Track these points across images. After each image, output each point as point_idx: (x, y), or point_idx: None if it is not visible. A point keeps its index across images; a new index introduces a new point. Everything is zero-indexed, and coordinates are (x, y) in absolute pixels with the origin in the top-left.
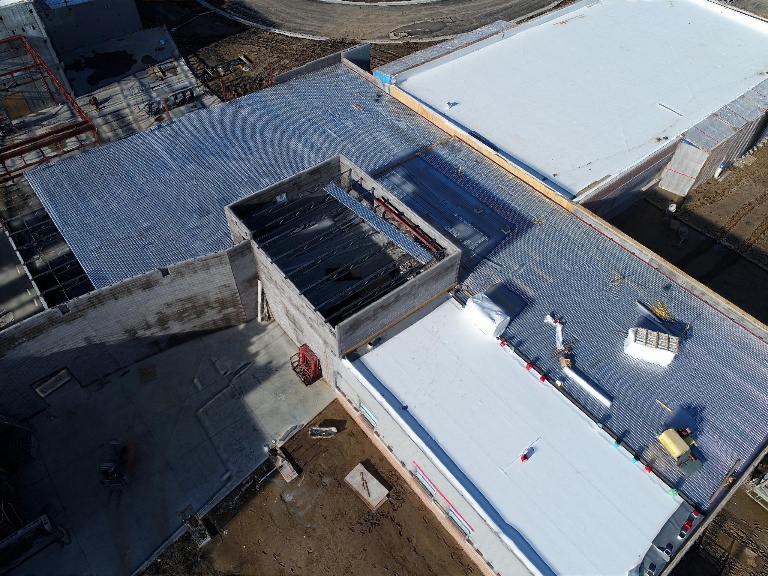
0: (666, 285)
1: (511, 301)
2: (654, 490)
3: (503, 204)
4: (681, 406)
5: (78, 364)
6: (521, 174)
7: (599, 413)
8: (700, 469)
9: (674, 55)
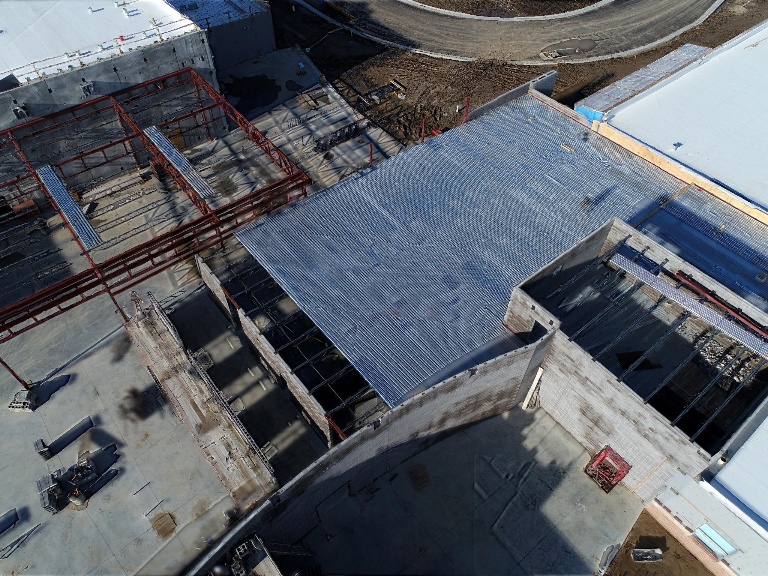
0: None
1: None
2: None
3: None
4: None
5: (359, 475)
6: None
7: None
8: None
9: None
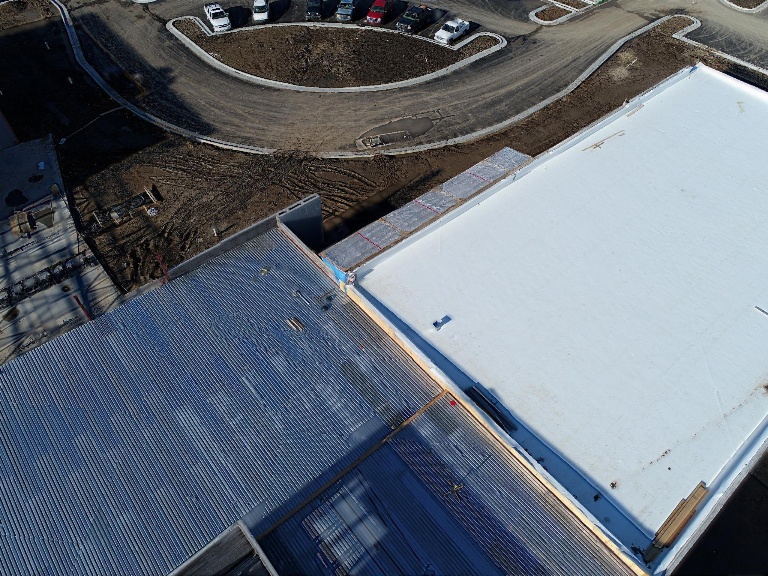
0: None
1: None
2: None
3: (531, 569)
4: None
5: None
6: (558, 493)
7: None
8: None
9: (761, 204)
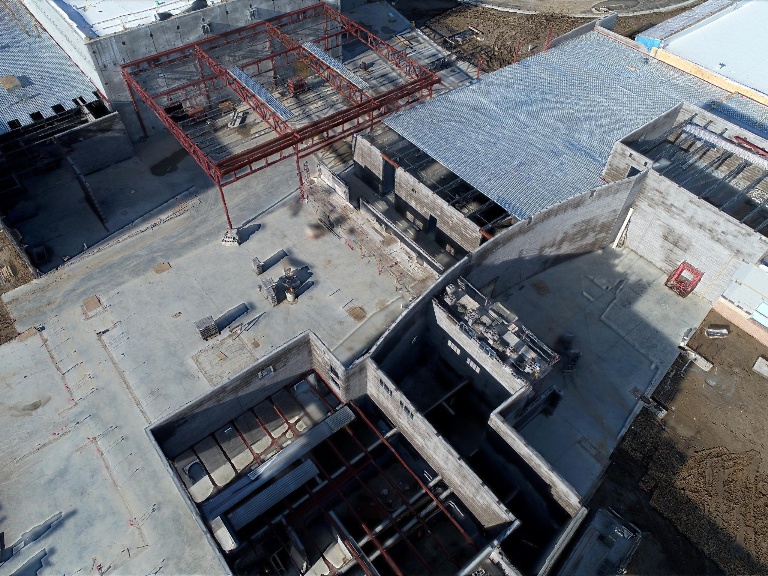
0: None
1: None
2: None
3: None
4: None
5: (504, 275)
6: None
7: None
8: None
9: None
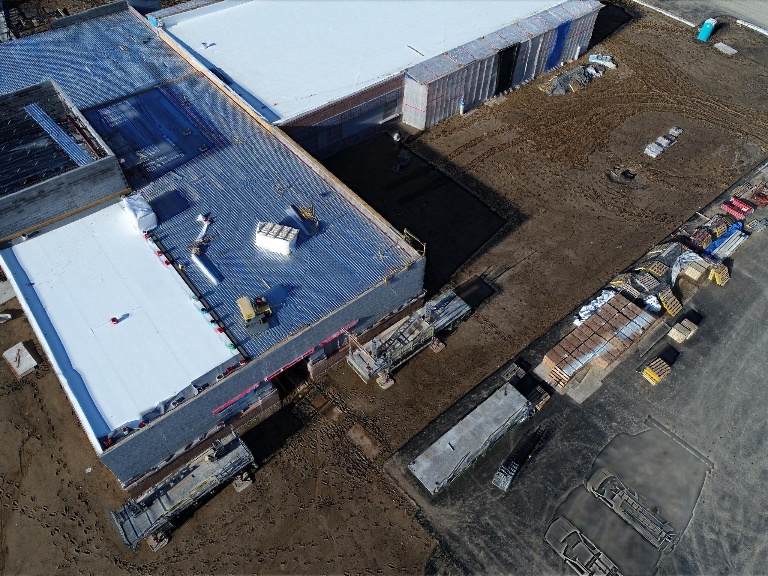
0: (326, 192)
1: (176, 204)
2: (217, 345)
3: (214, 128)
4: (281, 285)
5: None
6: (240, 103)
7: (205, 289)
8: (269, 331)
9: (446, 4)
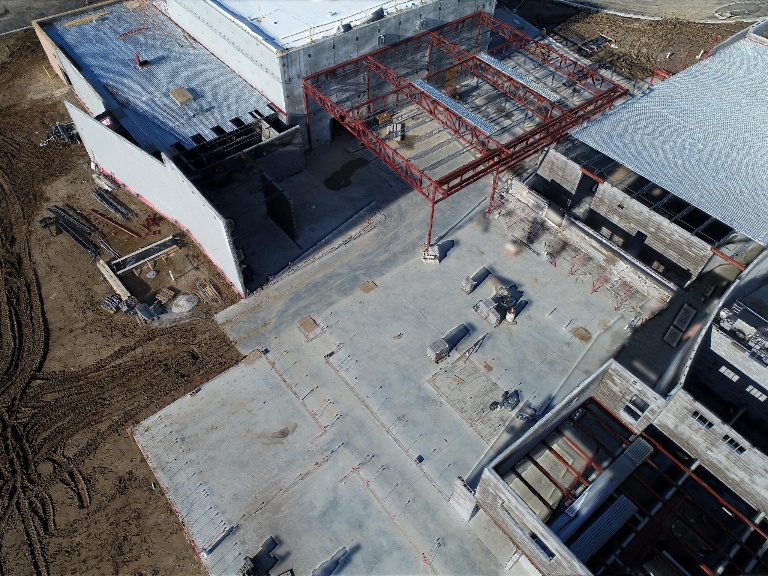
0: None
1: None
2: None
3: None
4: None
5: None
6: None
7: None
8: None
9: None
